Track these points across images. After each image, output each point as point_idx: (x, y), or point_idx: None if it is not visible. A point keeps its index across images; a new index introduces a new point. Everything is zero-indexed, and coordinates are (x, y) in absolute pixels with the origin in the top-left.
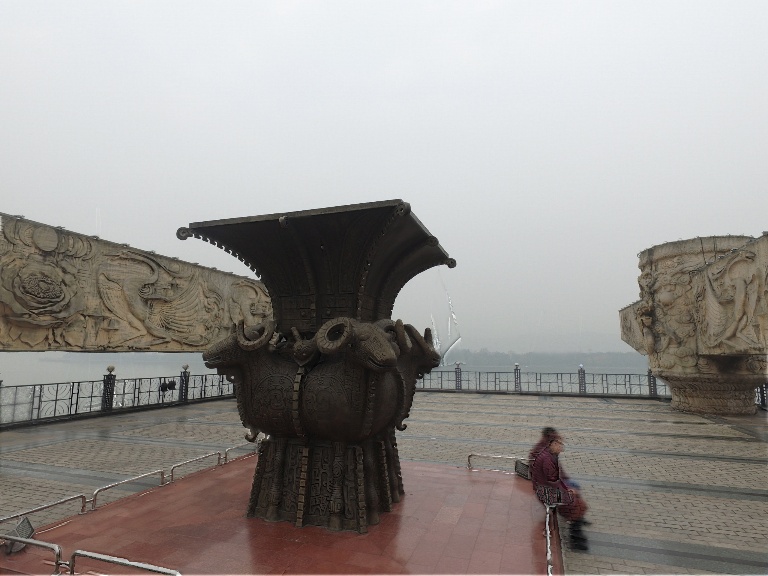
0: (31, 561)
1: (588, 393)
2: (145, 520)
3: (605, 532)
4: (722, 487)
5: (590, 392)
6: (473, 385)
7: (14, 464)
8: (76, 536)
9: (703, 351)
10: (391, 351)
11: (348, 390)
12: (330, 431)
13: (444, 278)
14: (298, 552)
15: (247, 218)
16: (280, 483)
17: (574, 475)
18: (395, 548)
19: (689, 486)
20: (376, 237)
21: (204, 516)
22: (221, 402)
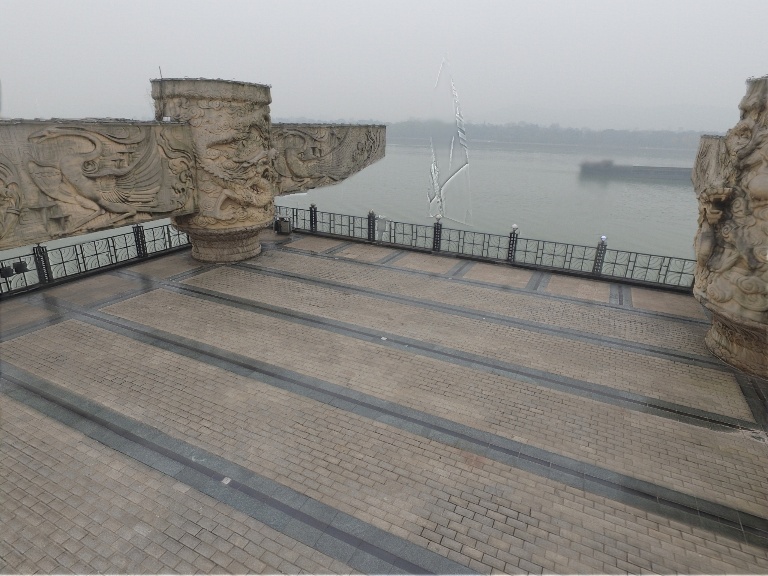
0: None
1: (604, 275)
2: None
3: None
4: None
5: (607, 274)
6: (455, 246)
7: None
8: None
9: None
10: None
11: None
12: None
13: (452, 77)
14: None
15: None
16: None
17: None
18: None
19: None
20: None
21: None
22: (105, 278)
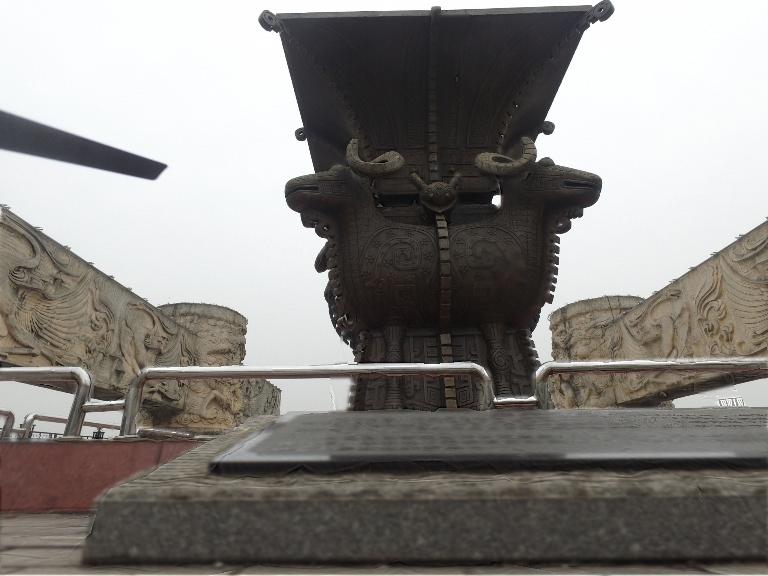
0: None
1: None
2: None
3: None
4: None
5: None
6: None
7: None
8: None
9: (623, 398)
10: None
11: (521, 237)
12: (491, 300)
13: None
14: None
15: (373, 12)
16: (401, 392)
17: None
18: None
19: None
20: (538, 65)
21: None
22: None
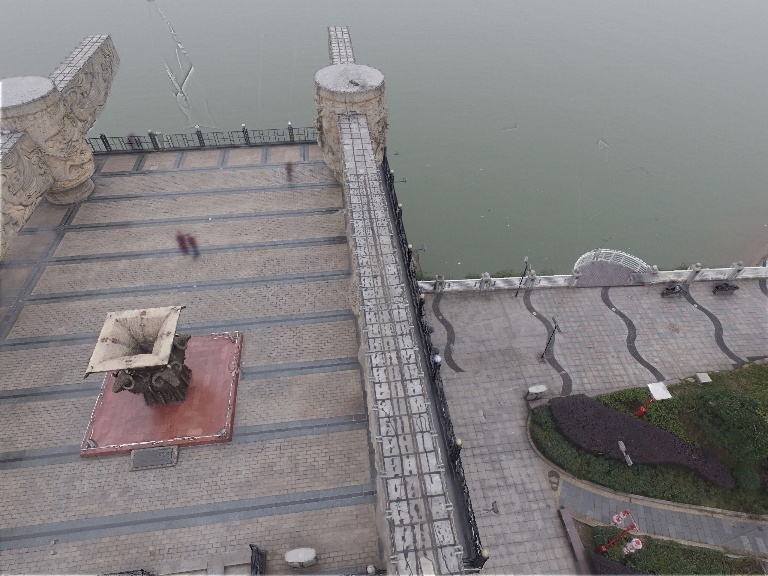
0: (104, 448)
1: (296, 141)
2: (117, 419)
3: (252, 366)
4: (300, 315)
5: (297, 140)
6: (213, 142)
7: (3, 395)
8: (104, 434)
9: None
10: (178, 382)
11: None
12: None
13: (157, 5)
14: (170, 417)
15: None
16: None
17: (253, 320)
18: (194, 405)
19: (289, 318)
20: None
21: (133, 410)
22: (20, 239)
